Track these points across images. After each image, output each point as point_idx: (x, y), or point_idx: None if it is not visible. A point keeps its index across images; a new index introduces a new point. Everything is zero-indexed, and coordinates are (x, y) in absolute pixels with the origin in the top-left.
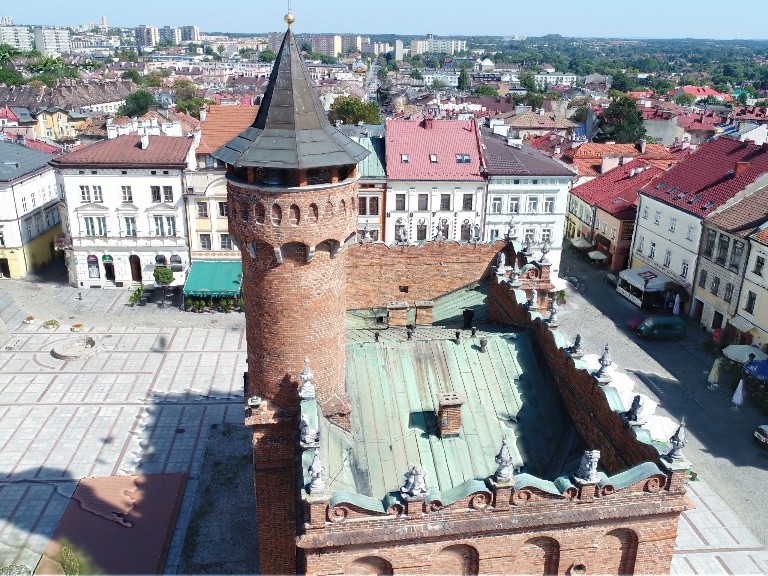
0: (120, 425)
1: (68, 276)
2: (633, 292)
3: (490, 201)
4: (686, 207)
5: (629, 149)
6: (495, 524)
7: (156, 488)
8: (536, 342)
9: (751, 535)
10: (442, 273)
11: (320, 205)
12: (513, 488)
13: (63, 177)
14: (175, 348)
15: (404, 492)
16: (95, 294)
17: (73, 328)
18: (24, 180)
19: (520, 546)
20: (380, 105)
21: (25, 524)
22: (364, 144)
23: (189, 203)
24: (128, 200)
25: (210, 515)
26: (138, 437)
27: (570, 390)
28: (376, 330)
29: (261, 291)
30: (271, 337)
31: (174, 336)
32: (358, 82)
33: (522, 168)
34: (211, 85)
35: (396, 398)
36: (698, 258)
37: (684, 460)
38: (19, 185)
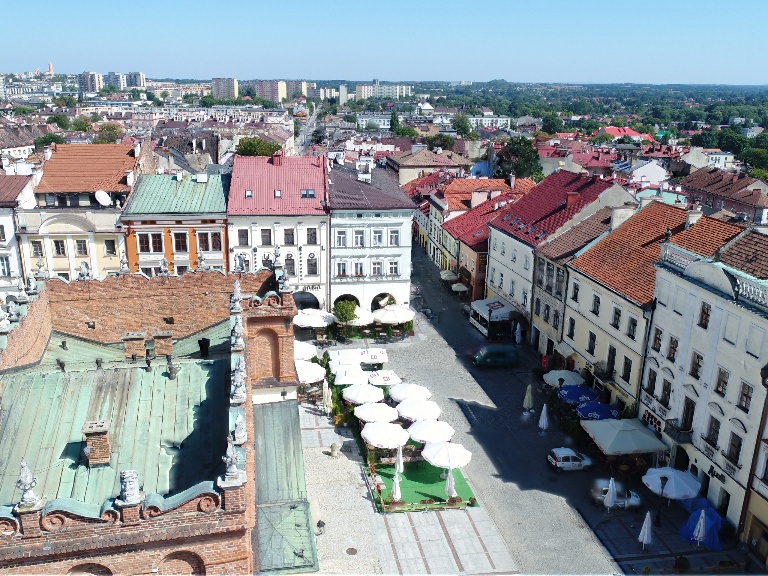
0: None
1: None
2: (482, 322)
3: (334, 235)
4: (523, 237)
5: (499, 184)
6: (23, 552)
7: None
8: None
9: (510, 559)
10: (208, 304)
11: None
12: (41, 513)
13: None
14: None
15: None
16: None
17: None
18: None
19: (64, 575)
20: (307, 147)
21: None
22: (213, 181)
23: (22, 242)
24: None
25: None
26: None
27: None
28: (113, 362)
29: None
30: None
31: None
32: (284, 125)
33: (365, 202)
34: (140, 129)
35: (58, 428)
36: (533, 287)
37: (238, 477)
38: None
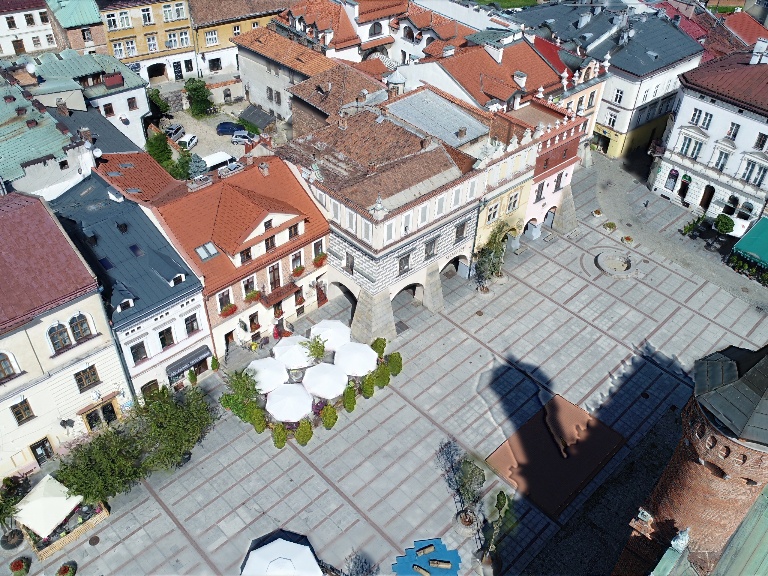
0: (606, 361)
1: (649, 176)
2: None
3: None
4: None
5: None
6: None
7: (598, 438)
8: None
9: None
10: None
11: (750, 458)
12: None
13: (684, 95)
14: (692, 304)
15: None
16: (661, 205)
17: (623, 239)
18: (655, 74)
19: None
20: None
21: (509, 408)
22: None
23: None
24: (731, 136)
25: (621, 487)
26: (612, 381)
27: None
28: None
29: (682, 465)
30: (675, 493)
31: (699, 289)
32: None
33: None
34: None
35: None
36: None
37: None
38: (649, 79)
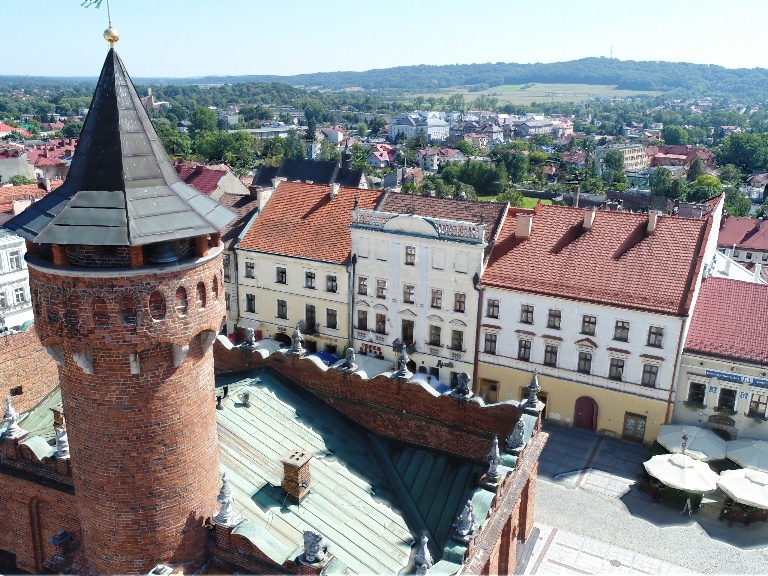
0: None
1: None
2: None
3: None
4: None
5: (33, 189)
6: (501, 522)
7: None
8: (280, 377)
9: None
10: None
11: (218, 276)
12: None
13: None
14: None
15: (466, 535)
16: None
17: None
18: None
19: None
20: None
21: None
22: None
23: None
24: None
25: None
26: None
27: (358, 403)
28: None
29: (149, 416)
30: (167, 473)
31: None
32: None
33: None
34: None
35: None
36: None
37: None
38: None
